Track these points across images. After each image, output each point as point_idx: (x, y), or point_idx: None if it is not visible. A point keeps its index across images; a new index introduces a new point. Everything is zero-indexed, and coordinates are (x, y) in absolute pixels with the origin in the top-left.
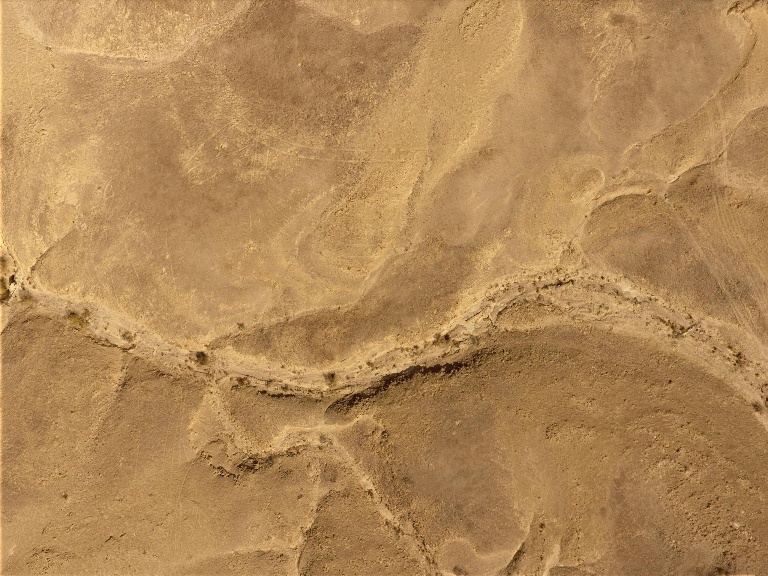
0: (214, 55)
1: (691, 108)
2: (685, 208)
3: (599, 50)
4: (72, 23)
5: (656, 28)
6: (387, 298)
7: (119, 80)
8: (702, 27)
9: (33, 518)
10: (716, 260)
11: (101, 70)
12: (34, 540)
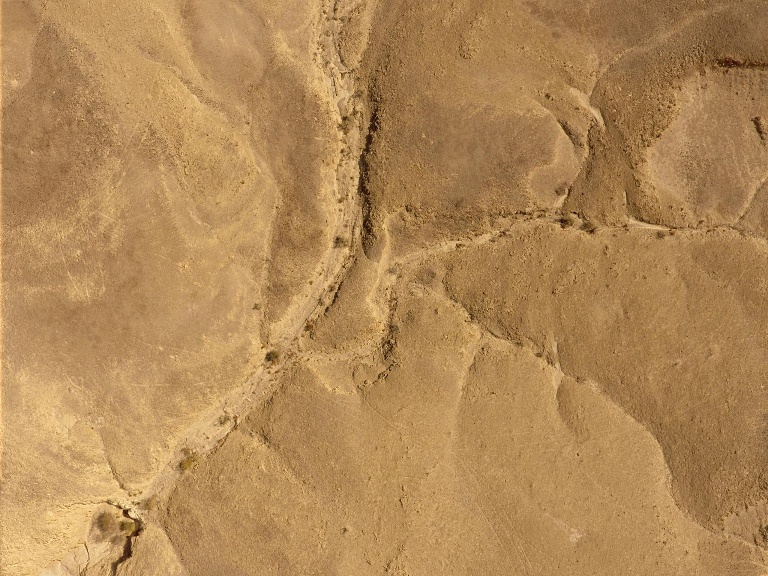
0: None
1: None
2: None
3: None
4: None
5: None
6: (285, 158)
7: None
8: None
9: (353, 569)
10: None
11: None
12: (374, 575)
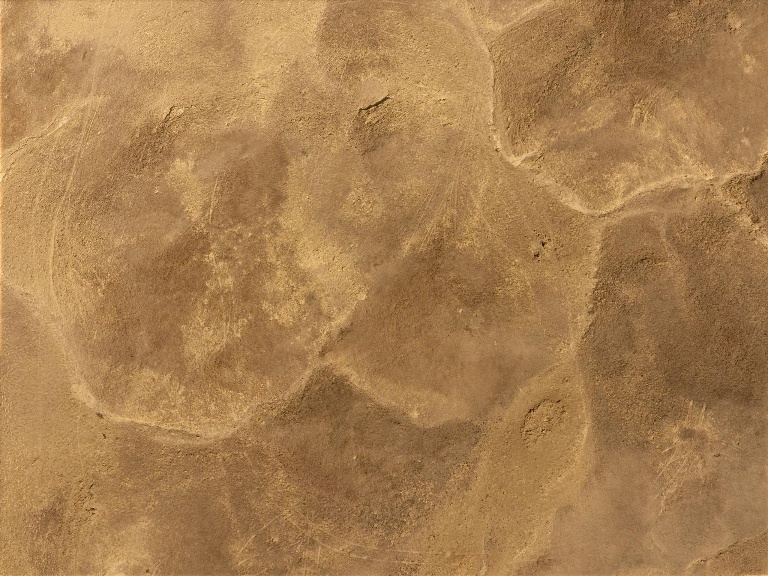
0: (267, 436)
1: (760, 526)
2: None
3: (666, 465)
4: (125, 394)
5: (728, 446)
6: None
7: (170, 455)
8: None
9: None
10: None
11: (152, 442)
12: None
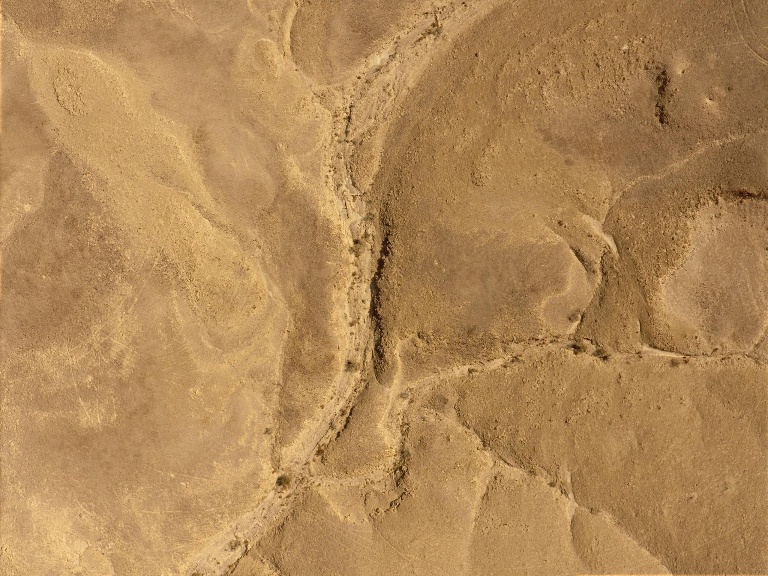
0: (2, 355)
1: None
2: None
3: None
4: None
5: None
6: (297, 283)
7: None
8: None
9: None
10: None
11: None
12: None
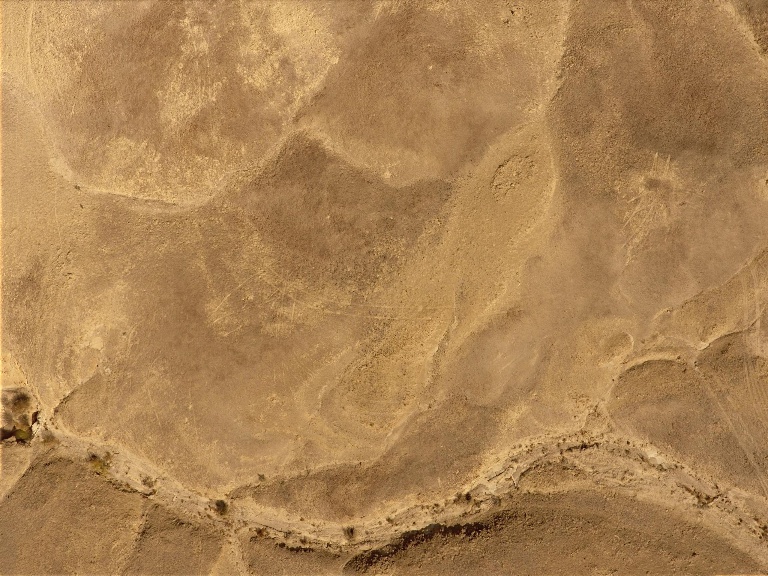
0: (242, 202)
1: (725, 275)
2: (715, 378)
3: (633, 215)
4: (102, 164)
5: (692, 194)
6: (409, 456)
7: (147, 223)
8: (739, 196)
9: None
10: (745, 432)
11: (129, 212)
12: None
